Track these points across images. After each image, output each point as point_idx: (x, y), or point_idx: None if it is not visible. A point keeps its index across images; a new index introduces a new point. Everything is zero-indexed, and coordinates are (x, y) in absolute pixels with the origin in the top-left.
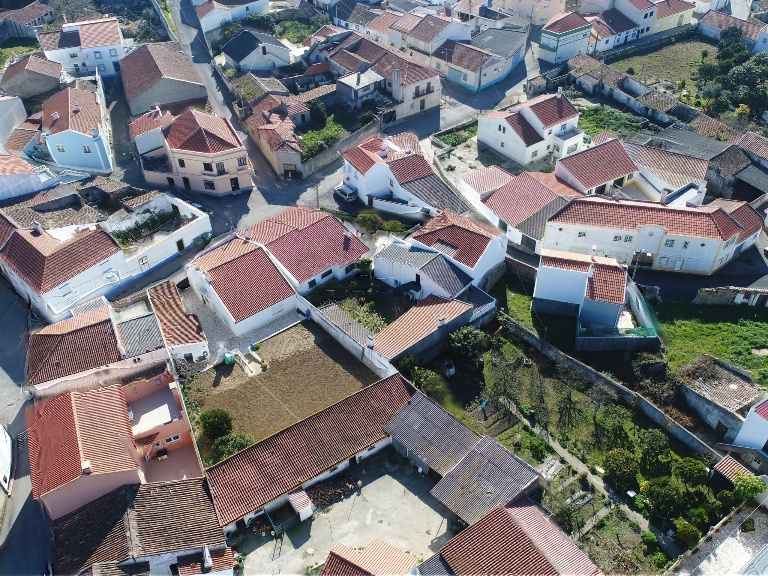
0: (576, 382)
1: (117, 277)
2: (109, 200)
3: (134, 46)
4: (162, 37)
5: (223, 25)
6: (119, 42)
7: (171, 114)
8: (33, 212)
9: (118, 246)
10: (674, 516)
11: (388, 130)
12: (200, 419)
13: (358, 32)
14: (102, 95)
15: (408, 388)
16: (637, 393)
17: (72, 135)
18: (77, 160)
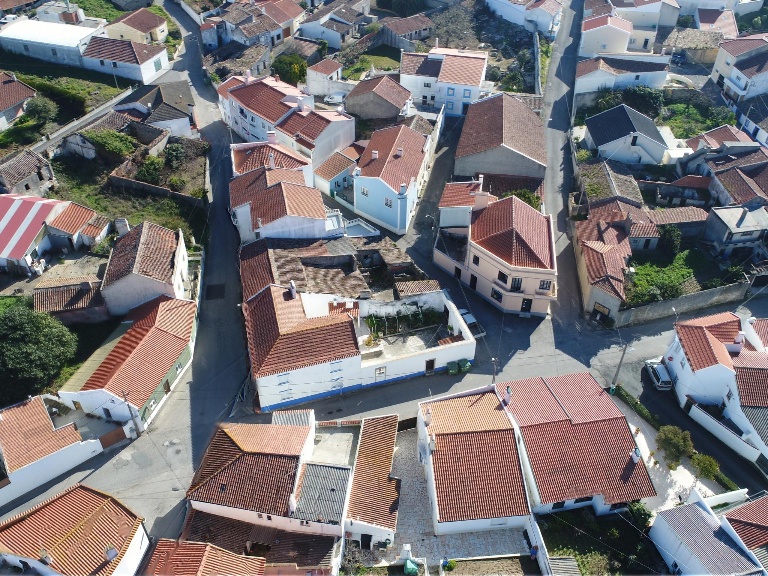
0: None
1: (344, 381)
2: (385, 270)
3: (491, 92)
4: (527, 86)
5: (600, 90)
6: (477, 84)
7: (492, 192)
8: (300, 265)
9: (358, 349)
10: None
11: (755, 303)
12: None
13: (767, 149)
14: (436, 138)
15: None
16: None
17: (380, 184)
18: (376, 209)
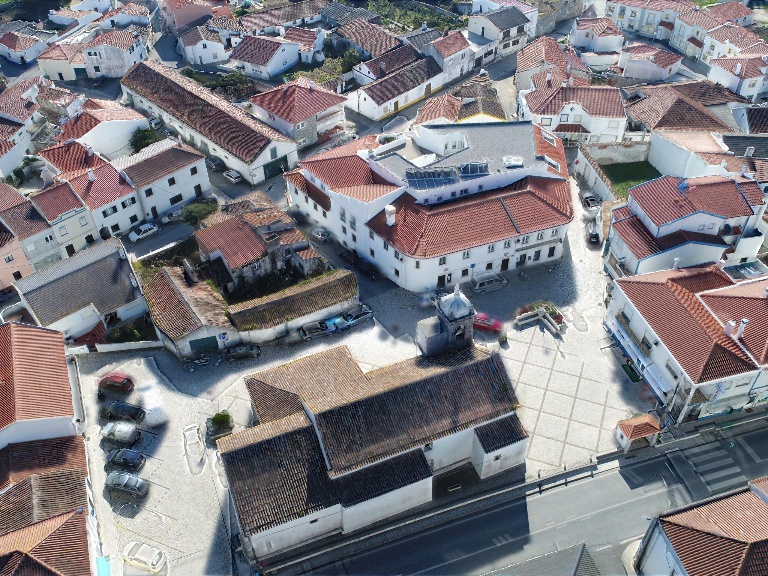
0: (409, 6)
1: None
2: None
3: None
4: None
5: None
6: None
7: None
8: None
9: None
10: (434, 26)
11: None
12: (236, 12)
13: None
14: None
15: (330, 1)
16: (435, 6)
17: None
18: None
